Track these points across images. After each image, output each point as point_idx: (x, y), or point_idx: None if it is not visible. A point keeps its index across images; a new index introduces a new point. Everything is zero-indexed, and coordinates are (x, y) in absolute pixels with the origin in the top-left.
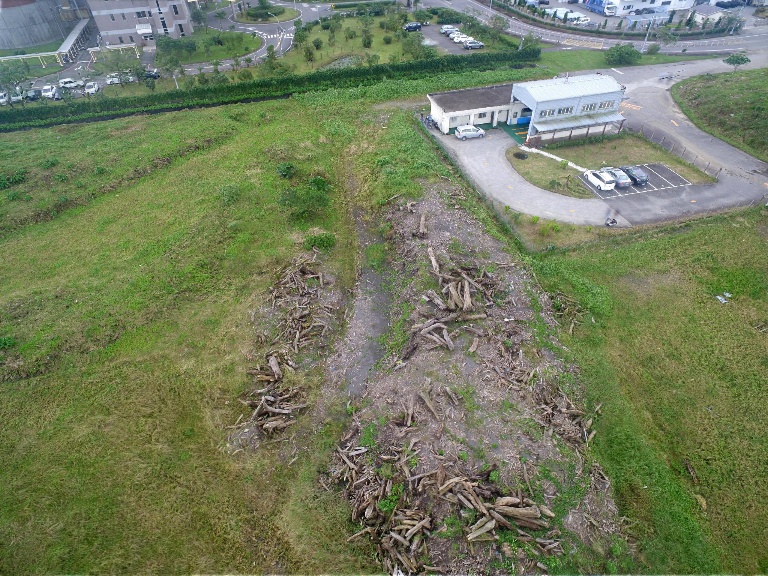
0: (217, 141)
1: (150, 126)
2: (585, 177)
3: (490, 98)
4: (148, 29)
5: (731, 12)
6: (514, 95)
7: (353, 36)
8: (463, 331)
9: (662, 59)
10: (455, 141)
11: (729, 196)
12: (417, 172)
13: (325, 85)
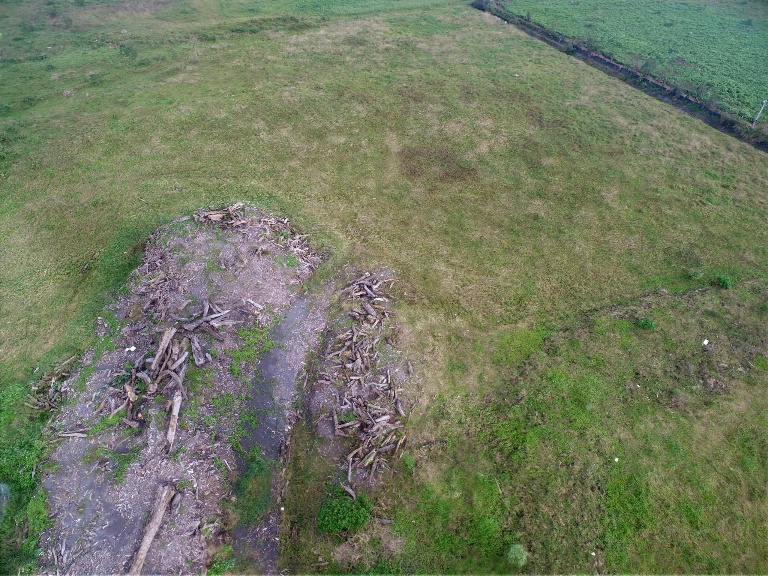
0: None
1: None
2: None
3: None
4: None
5: None
6: None
7: None
8: None
9: None
10: None
11: None
12: None
13: None
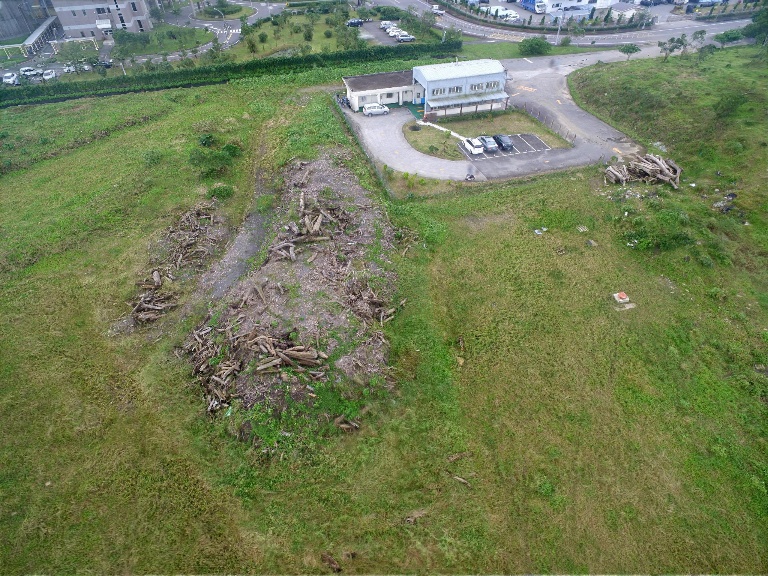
0: (153, 118)
1: (95, 106)
2: (463, 144)
3: (397, 80)
4: (107, 24)
5: (641, 9)
6: (414, 77)
7: (298, 31)
8: (308, 249)
9: (572, 50)
10: (362, 117)
11: (578, 158)
12: (317, 140)
13: (261, 72)
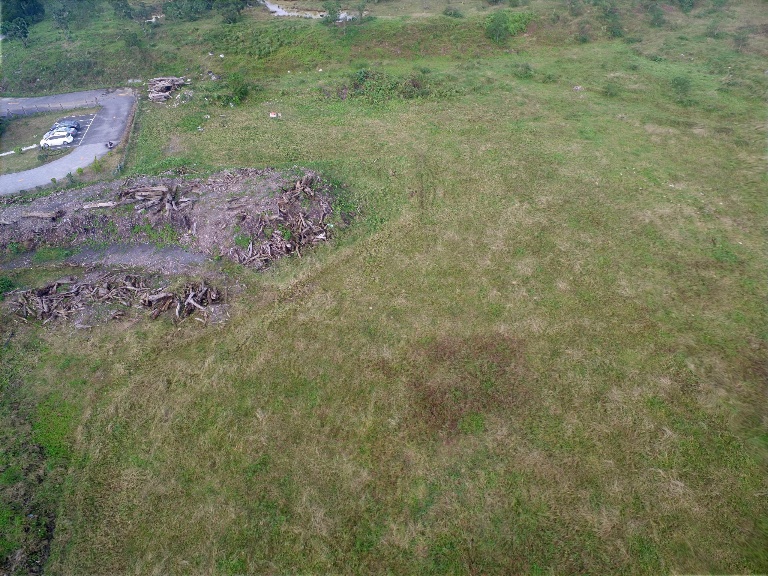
0: None
1: None
2: None
3: None
4: None
5: None
6: None
7: None
8: None
9: None
10: None
11: (120, 107)
12: None
13: None
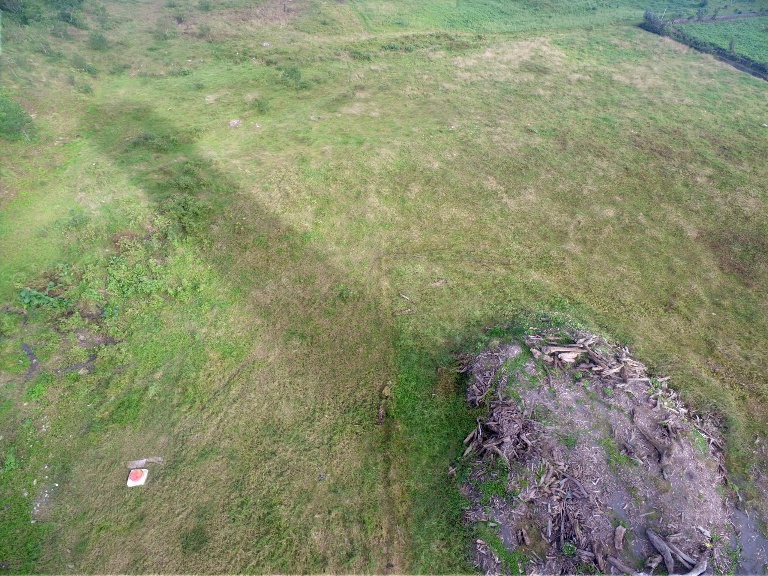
0: None
1: None
2: None
3: None
4: None
5: None
6: None
7: None
8: (641, 571)
9: None
10: None
11: None
12: None
13: None
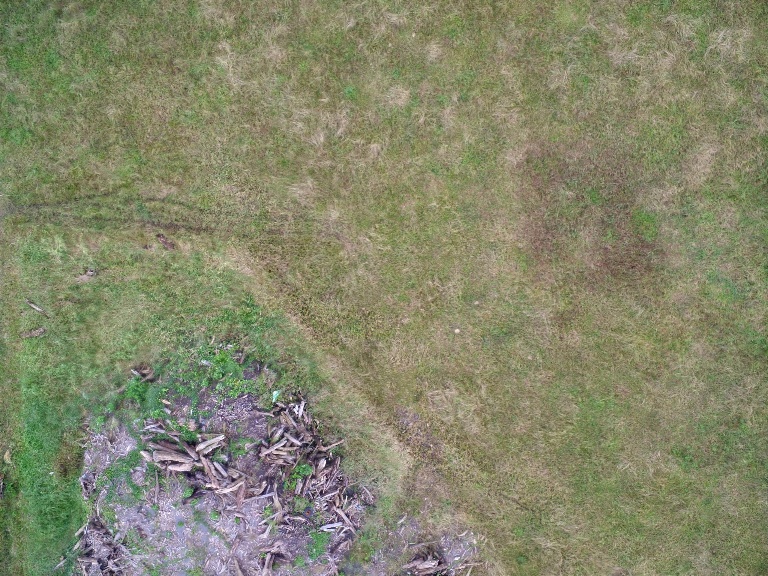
0: None
1: None
2: None
3: None
4: None
5: None
6: None
7: None
8: None
9: None
10: None
11: None
12: None
13: None
